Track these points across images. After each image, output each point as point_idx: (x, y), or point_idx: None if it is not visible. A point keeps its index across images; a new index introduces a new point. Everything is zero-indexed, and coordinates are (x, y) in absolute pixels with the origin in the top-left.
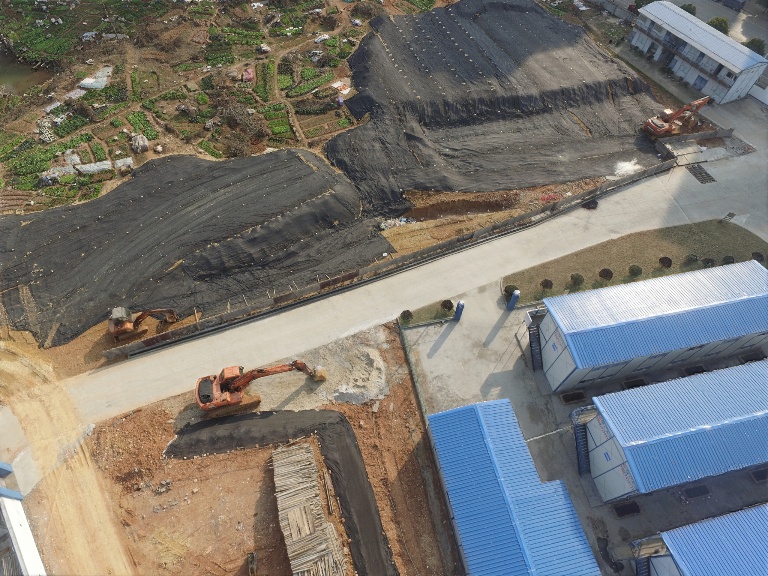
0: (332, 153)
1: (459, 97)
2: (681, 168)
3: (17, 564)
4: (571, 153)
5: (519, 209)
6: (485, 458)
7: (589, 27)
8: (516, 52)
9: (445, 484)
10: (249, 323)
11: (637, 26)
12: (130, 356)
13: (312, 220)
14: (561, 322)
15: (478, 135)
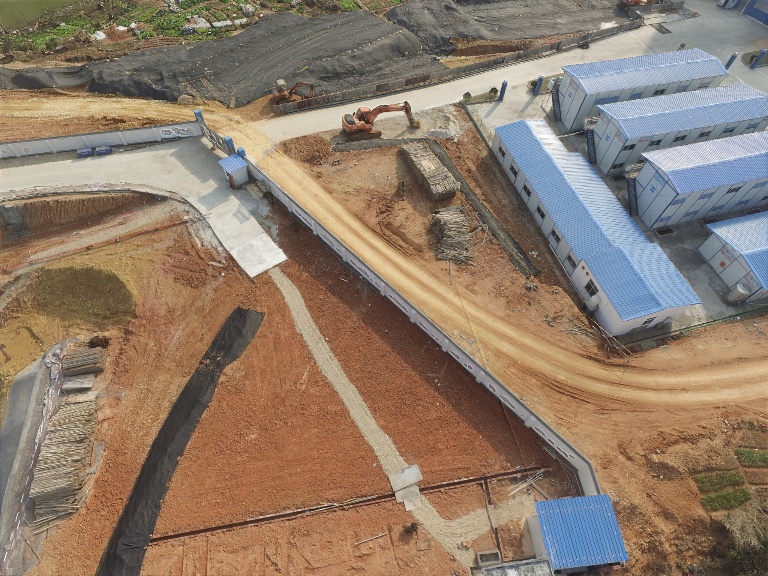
0: (393, 17)
1: None
2: (647, 26)
3: (265, 184)
4: (567, 18)
5: None
6: (534, 141)
7: None
8: None
9: (511, 155)
10: (361, 101)
11: None
12: (289, 113)
13: (390, 49)
14: (574, 74)
15: (498, 9)
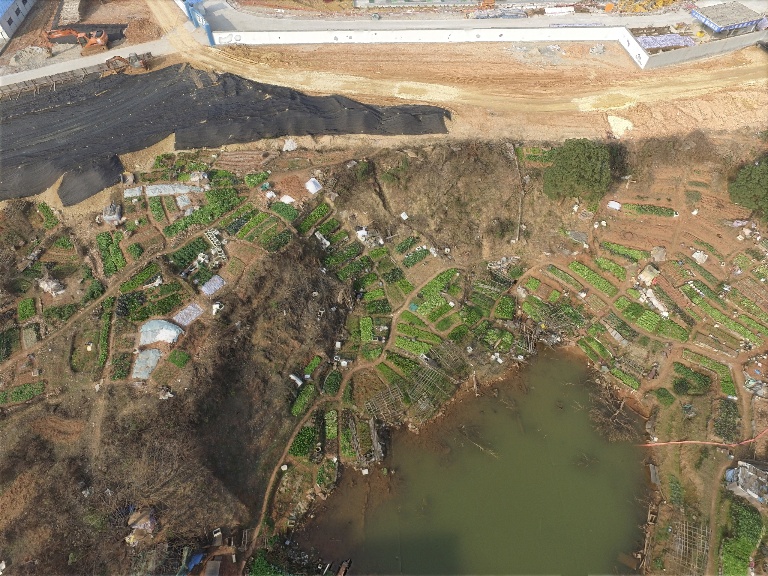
0: None
1: None
2: None
3: None
4: None
5: None
6: None
7: None
8: None
9: (11, 5)
10: None
11: None
12: None
13: None
14: None
15: None
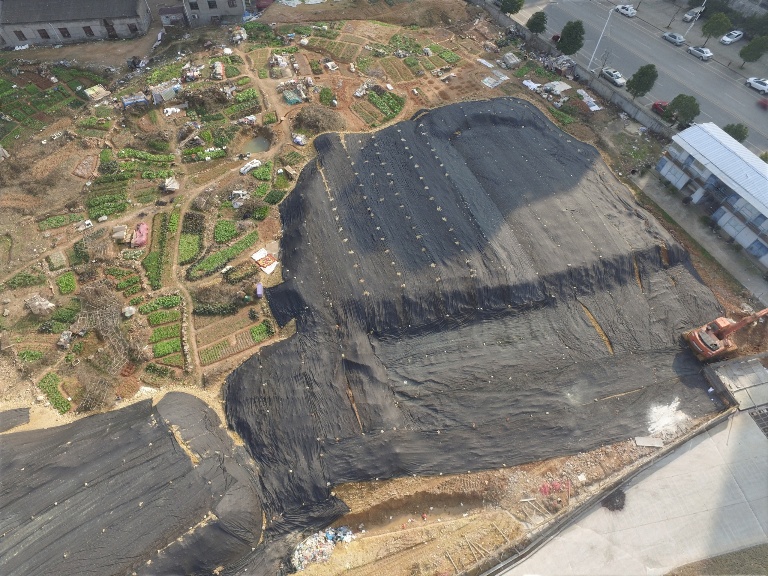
0: (232, 404)
1: (425, 291)
2: (744, 416)
3: None
4: (584, 388)
5: (507, 510)
6: None
7: (604, 143)
8: (507, 199)
9: None
10: None
11: (670, 156)
12: None
13: None
14: None
15: (451, 351)
